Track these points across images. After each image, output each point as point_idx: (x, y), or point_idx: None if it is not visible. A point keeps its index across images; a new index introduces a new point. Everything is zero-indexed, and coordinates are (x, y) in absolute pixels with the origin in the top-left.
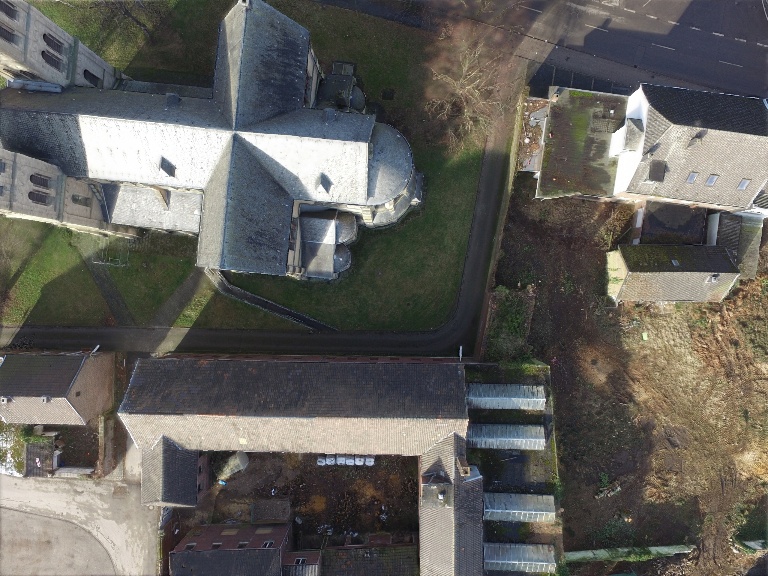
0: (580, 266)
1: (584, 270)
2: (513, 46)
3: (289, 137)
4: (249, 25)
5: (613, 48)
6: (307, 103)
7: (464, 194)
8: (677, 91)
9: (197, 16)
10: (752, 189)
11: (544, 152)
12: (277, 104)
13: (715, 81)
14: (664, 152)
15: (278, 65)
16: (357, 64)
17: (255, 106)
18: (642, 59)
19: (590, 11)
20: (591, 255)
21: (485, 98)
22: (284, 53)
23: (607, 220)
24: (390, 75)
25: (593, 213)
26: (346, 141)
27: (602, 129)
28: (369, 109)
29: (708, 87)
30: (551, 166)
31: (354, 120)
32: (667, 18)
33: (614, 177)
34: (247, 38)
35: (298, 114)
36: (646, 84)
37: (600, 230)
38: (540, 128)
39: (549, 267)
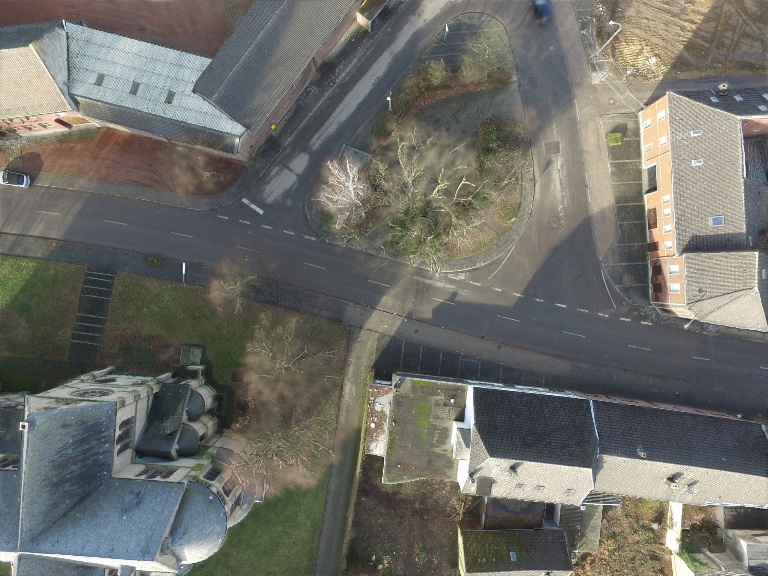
0: (433, 536)
1: (437, 540)
2: (363, 320)
3: (75, 556)
4: (32, 443)
5: (460, 320)
6: (130, 441)
7: (317, 470)
8: (507, 395)
9: (43, 299)
10: (578, 495)
11: (388, 440)
12: (76, 493)
13: (559, 351)
14: (488, 472)
15: (75, 457)
16: (206, 346)
17: (46, 512)
18: (489, 330)
19: (437, 285)
20: (444, 525)
21: (336, 373)
22: (83, 441)
23: (459, 490)
24: (239, 356)
25: (445, 484)
26: (132, 560)
27: (444, 416)
28: (217, 395)
29: (553, 356)
30: (396, 453)
31: (158, 500)
32: (511, 290)
33: (457, 462)
34: (31, 456)
35: (102, 495)
36: (478, 387)
37: (452, 500)
38: (385, 414)
39: (403, 538)
